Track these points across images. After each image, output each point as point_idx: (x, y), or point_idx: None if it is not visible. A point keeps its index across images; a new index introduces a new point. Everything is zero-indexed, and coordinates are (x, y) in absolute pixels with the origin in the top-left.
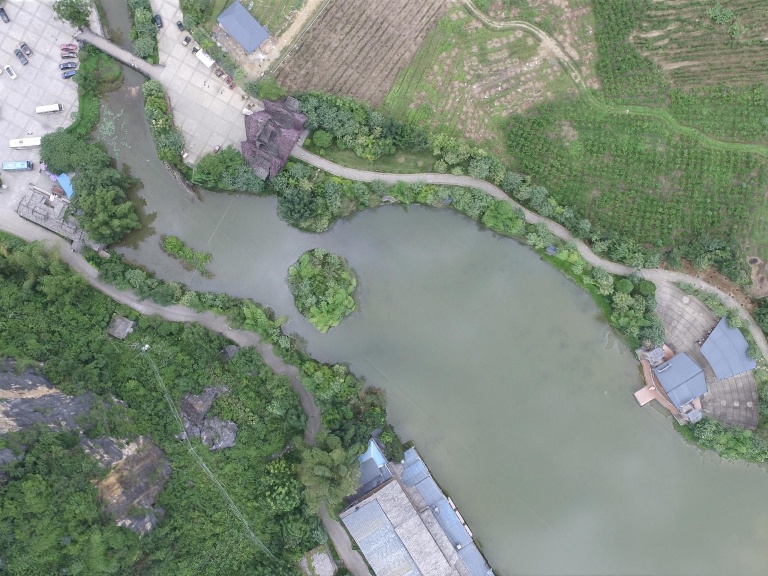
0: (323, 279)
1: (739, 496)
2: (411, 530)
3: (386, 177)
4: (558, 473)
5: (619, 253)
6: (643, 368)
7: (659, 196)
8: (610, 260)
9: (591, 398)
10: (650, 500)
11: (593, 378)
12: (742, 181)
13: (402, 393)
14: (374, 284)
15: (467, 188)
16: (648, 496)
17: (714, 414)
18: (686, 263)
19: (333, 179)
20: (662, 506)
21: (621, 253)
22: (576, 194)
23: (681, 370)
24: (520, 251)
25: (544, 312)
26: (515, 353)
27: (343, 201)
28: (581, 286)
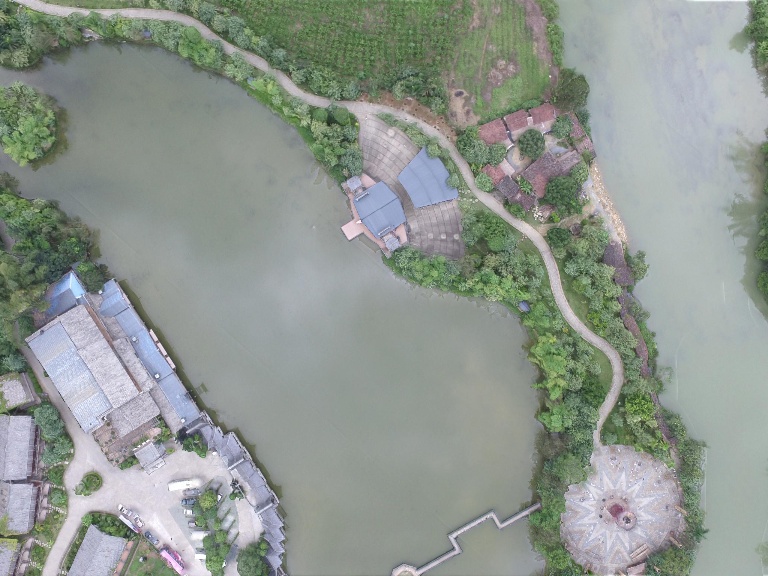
0: (16, 109)
1: (449, 330)
2: (96, 353)
3: (88, 12)
4: (267, 308)
5: (314, 82)
6: (350, 202)
7: (362, 29)
8: (313, 93)
9: (299, 233)
10: (359, 334)
11: (301, 213)
12: (445, 13)
13: (109, 229)
14: (80, 121)
15: (168, 22)
16: (357, 330)
17: (421, 247)
18: (390, 96)
19: (26, 10)
20: (371, 340)
21: (316, 81)
22: (278, 27)
23: (377, 198)
24: (230, 89)
25: (251, 148)
26: (222, 188)
27: (33, 30)
28: (287, 121)
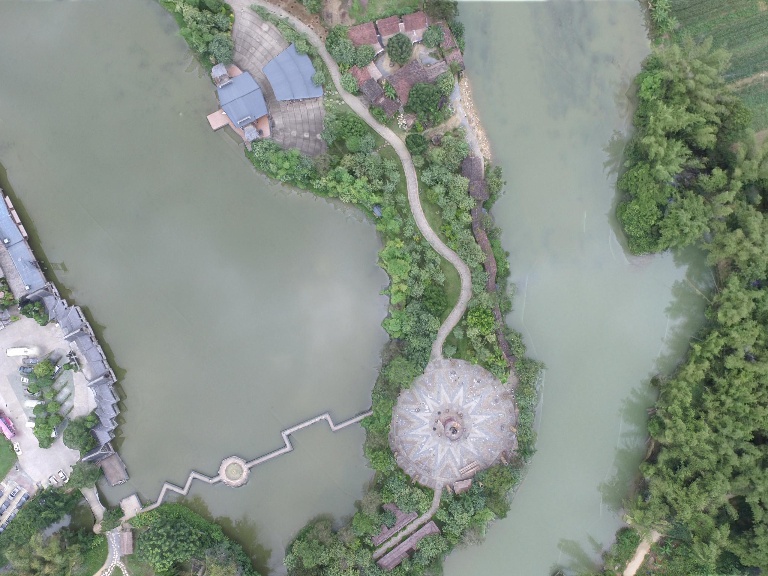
0: None
1: (304, 228)
2: None
3: None
4: (126, 189)
5: None
6: None
7: None
8: None
9: (166, 118)
10: (214, 224)
11: (169, 99)
12: None
13: None
14: None
15: None
16: (213, 220)
17: (284, 143)
18: None
19: None
20: (226, 231)
21: None
22: None
23: (240, 86)
24: None
25: (127, 30)
26: (94, 67)
27: None
28: (165, 6)
